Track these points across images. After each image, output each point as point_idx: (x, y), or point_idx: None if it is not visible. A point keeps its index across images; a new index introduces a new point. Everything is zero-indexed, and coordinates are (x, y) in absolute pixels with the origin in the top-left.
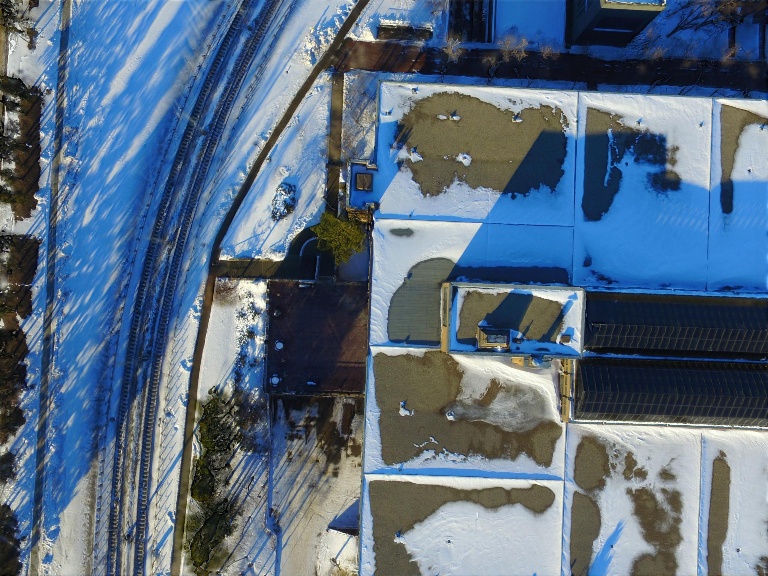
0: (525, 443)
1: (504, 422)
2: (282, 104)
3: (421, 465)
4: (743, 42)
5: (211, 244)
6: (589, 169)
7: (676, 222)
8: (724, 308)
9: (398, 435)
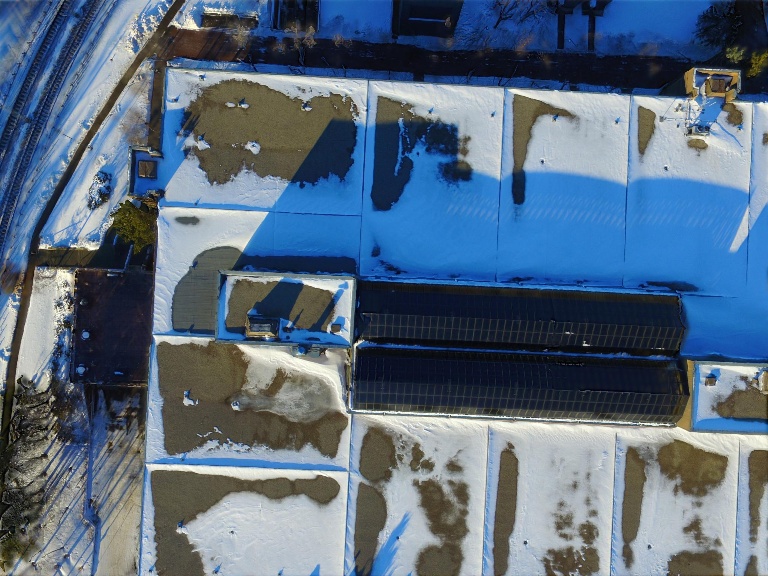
0: (310, 434)
1: (290, 412)
2: (104, 92)
3: (204, 455)
4: (572, 34)
5: (31, 233)
6: (379, 158)
7: (466, 212)
8: (502, 299)
9: (181, 425)
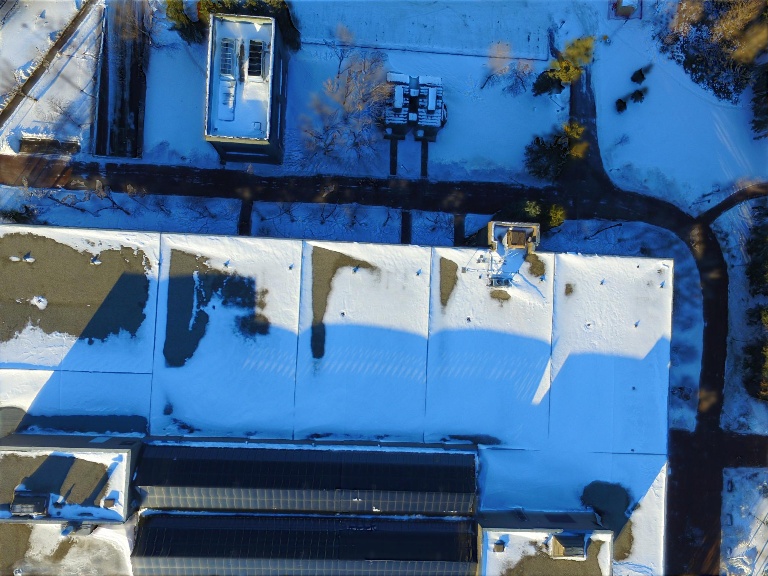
0: None
1: None
2: None
3: None
4: (404, 160)
5: None
6: (172, 313)
7: (263, 368)
8: (290, 465)
9: None
